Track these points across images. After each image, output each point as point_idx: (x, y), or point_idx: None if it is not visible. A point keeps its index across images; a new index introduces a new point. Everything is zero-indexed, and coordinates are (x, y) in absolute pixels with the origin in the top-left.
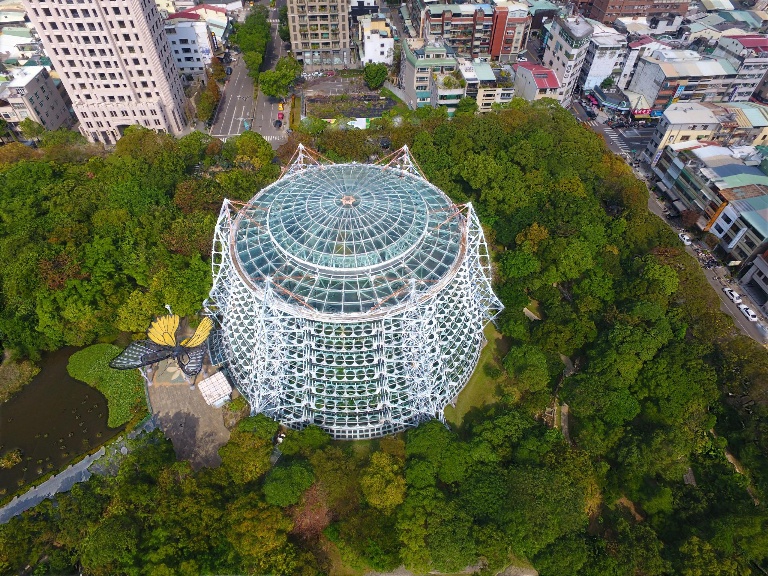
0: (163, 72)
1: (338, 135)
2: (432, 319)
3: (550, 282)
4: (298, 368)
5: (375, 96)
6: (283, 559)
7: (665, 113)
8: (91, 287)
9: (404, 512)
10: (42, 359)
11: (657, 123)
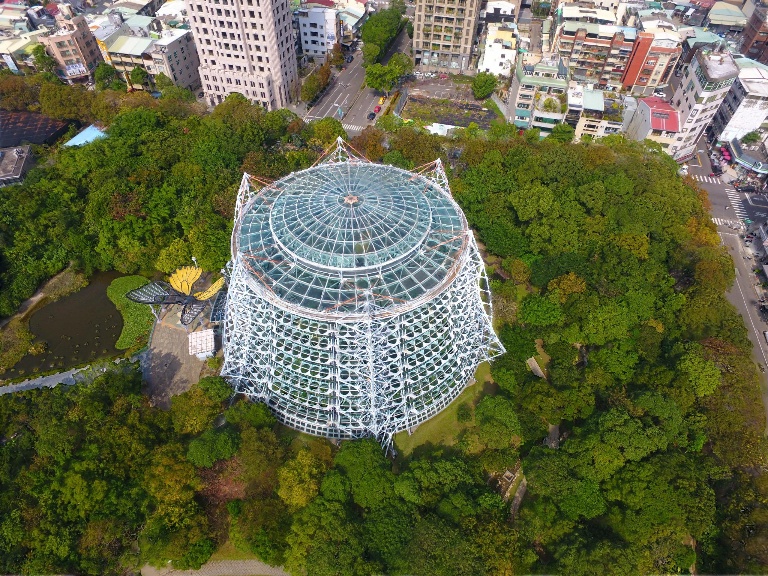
0: (277, 50)
1: (409, 137)
2: (397, 338)
3: (570, 340)
4: (263, 346)
5: (478, 106)
6: (179, 513)
7: None
8: (143, 225)
9: (301, 516)
10: (93, 275)
11: None
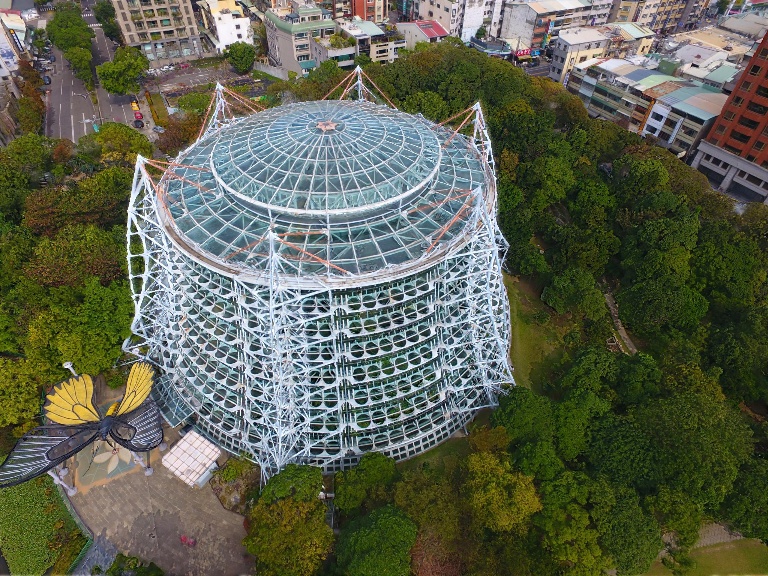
0: None
1: None
2: None
3: (539, 209)
4: (324, 378)
5: (248, 80)
6: None
7: (561, 37)
8: None
9: (552, 519)
10: None
11: (538, 62)
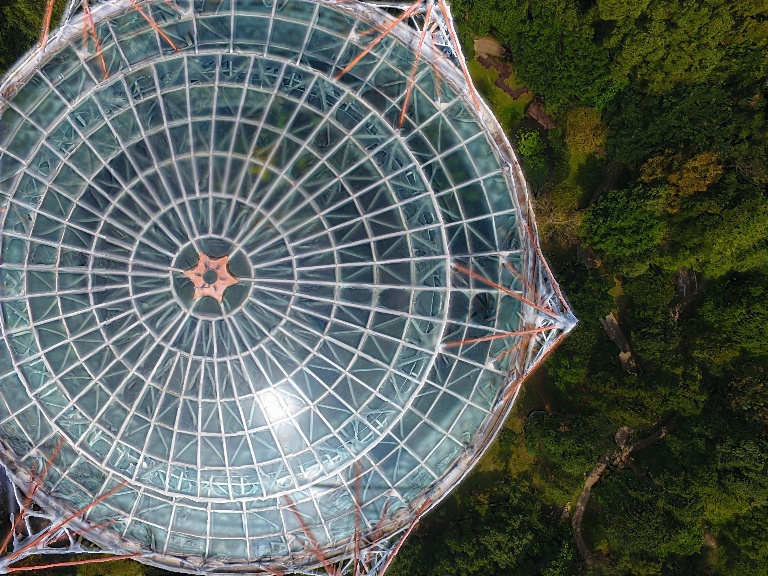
0: None
1: None
2: None
3: (666, 267)
4: None
5: None
6: None
7: None
8: None
9: None
10: None
11: None
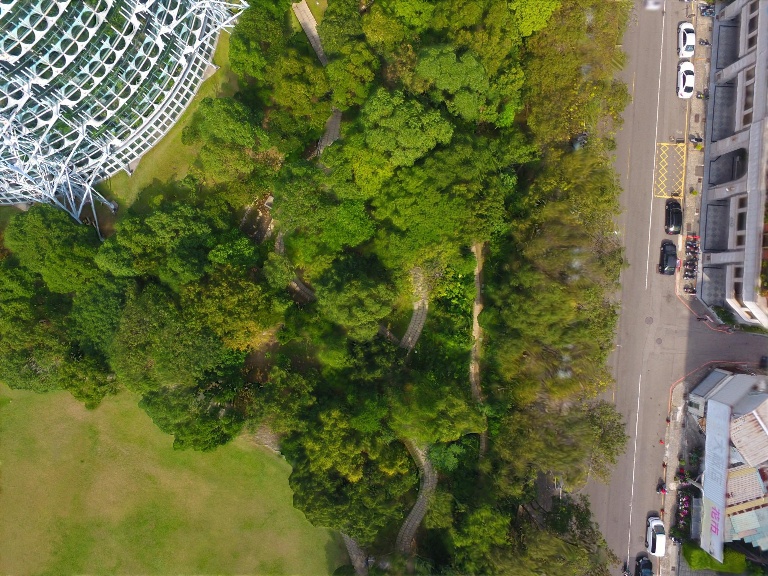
0: None
1: None
2: None
3: None
4: None
5: None
6: None
7: None
8: None
9: None
10: None
11: None
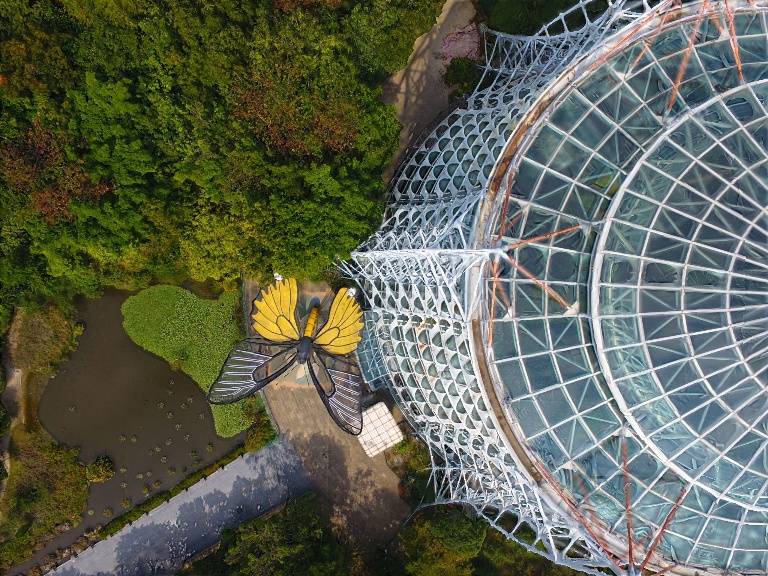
0: None
1: None
2: None
3: None
4: None
5: None
6: None
7: None
8: (124, 222)
9: None
10: (78, 308)
11: None
